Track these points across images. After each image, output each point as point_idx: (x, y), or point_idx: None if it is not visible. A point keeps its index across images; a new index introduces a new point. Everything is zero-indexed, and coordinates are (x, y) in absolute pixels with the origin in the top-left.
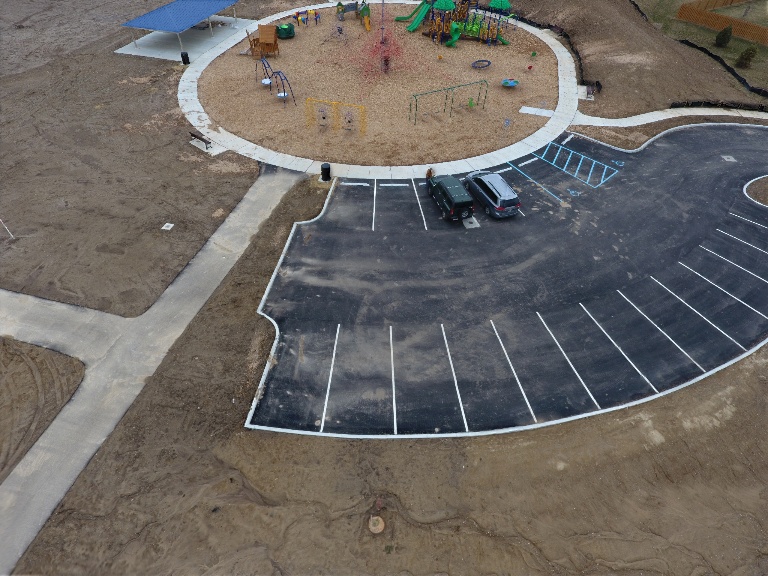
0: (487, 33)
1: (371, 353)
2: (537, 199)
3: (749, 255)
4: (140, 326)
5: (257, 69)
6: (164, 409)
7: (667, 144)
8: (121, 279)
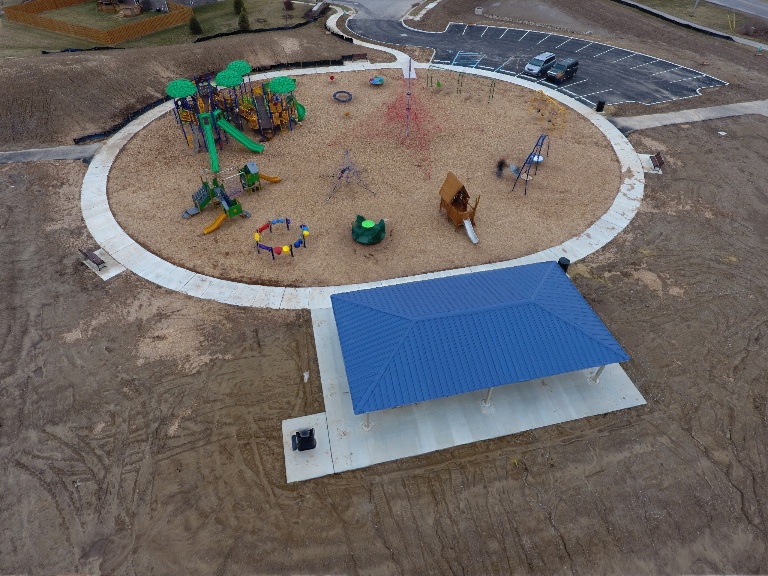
0: (270, 95)
1: (667, 75)
2: (519, 63)
3: (492, 33)
4: (760, 111)
5: (498, 208)
6: (759, 94)
7: (408, 44)
8: (763, 126)
